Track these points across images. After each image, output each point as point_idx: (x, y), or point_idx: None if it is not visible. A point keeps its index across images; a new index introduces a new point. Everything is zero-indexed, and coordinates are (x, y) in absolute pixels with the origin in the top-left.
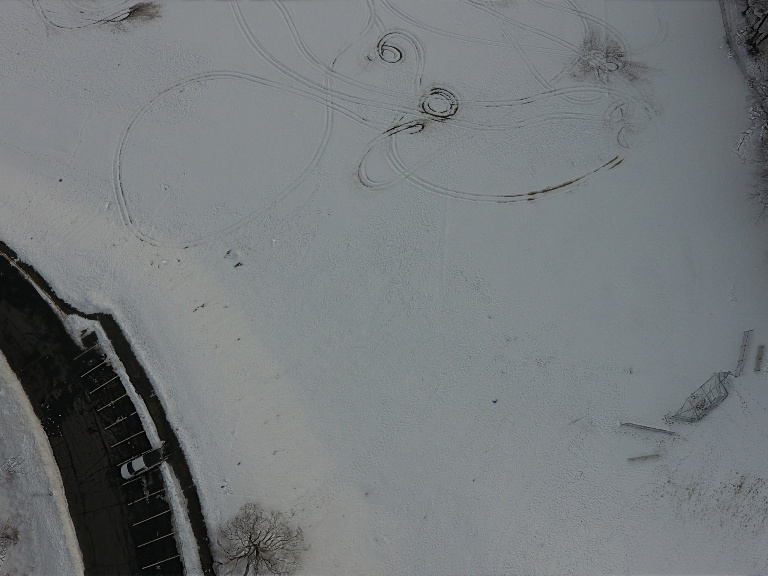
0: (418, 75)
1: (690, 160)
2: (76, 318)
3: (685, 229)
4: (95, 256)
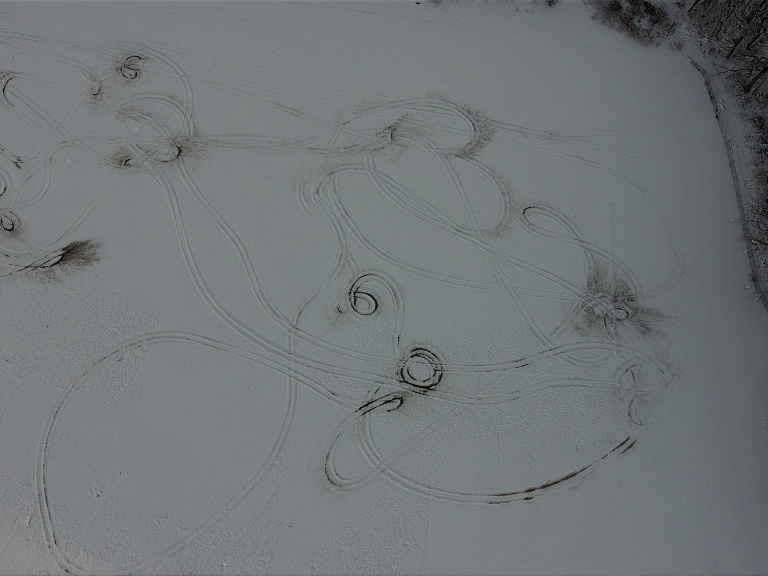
0: (396, 331)
1: (714, 440)
2: None
3: (710, 536)
4: None
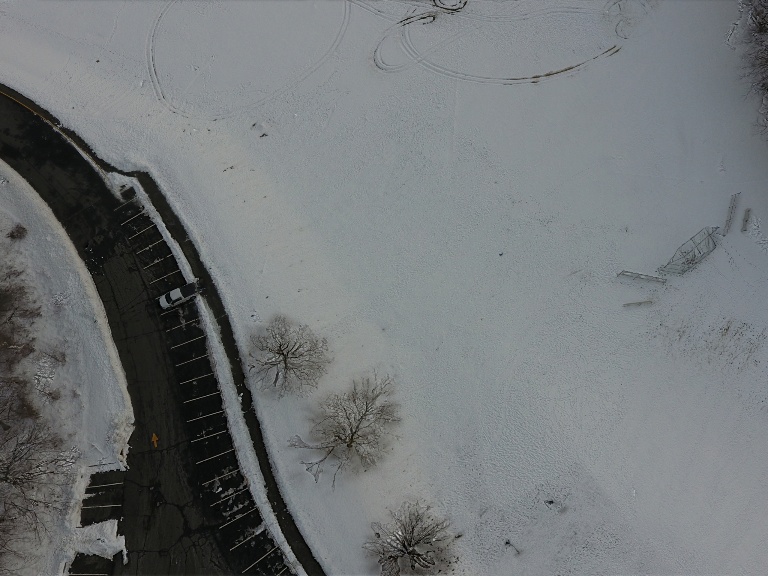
0: None
1: (683, 49)
2: (116, 175)
3: (678, 109)
4: (132, 123)
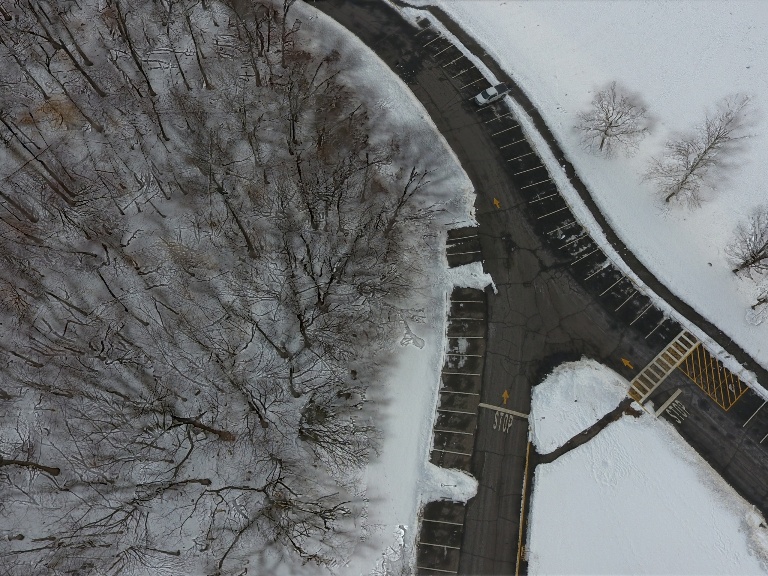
0: None
1: None
2: (410, 9)
3: None
4: None
